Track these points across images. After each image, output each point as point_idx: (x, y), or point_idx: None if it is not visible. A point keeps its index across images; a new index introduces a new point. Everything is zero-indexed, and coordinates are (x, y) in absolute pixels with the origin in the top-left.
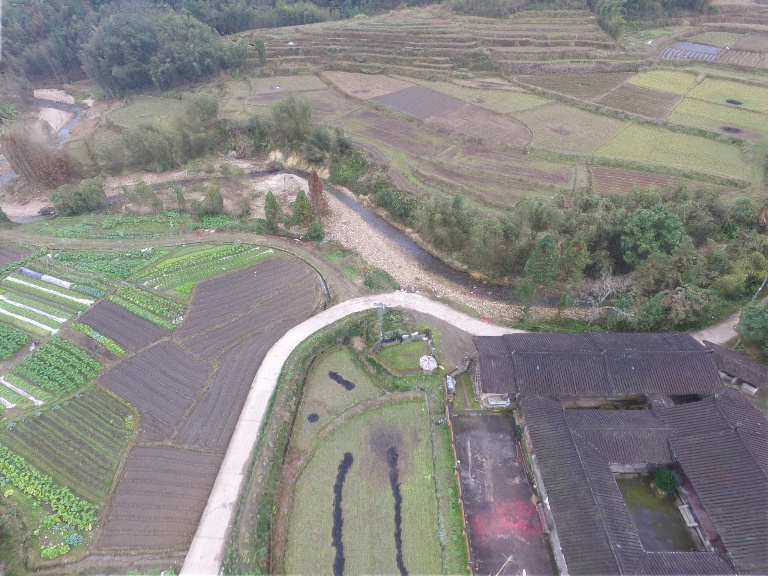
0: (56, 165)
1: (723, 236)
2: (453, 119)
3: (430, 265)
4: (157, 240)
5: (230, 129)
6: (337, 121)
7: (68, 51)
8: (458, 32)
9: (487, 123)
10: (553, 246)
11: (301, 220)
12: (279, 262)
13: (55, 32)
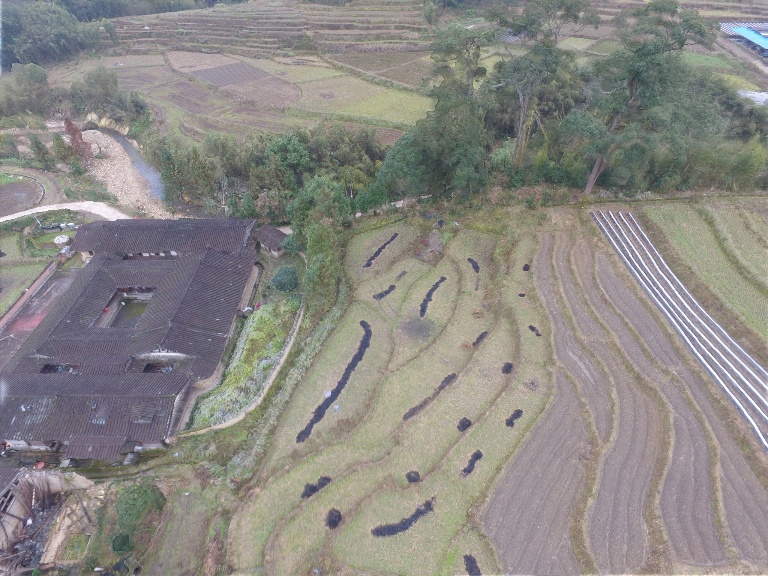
0: None
1: None
2: (245, 87)
3: (158, 193)
4: None
5: (58, 95)
6: (150, 89)
7: None
8: (294, 18)
9: (271, 90)
10: (170, 158)
11: (61, 158)
12: (20, 184)
13: None
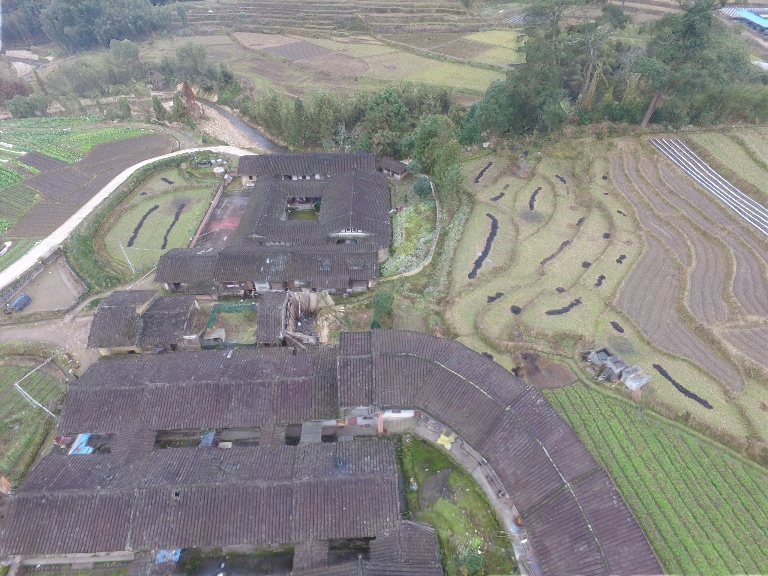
0: (13, 87)
1: (442, 115)
2: (316, 61)
3: (264, 145)
4: (77, 127)
5: (148, 69)
6: (230, 63)
7: (34, 19)
8: (344, 2)
9: (340, 63)
10: None
11: (178, 116)
12: (154, 135)
13: (23, 4)
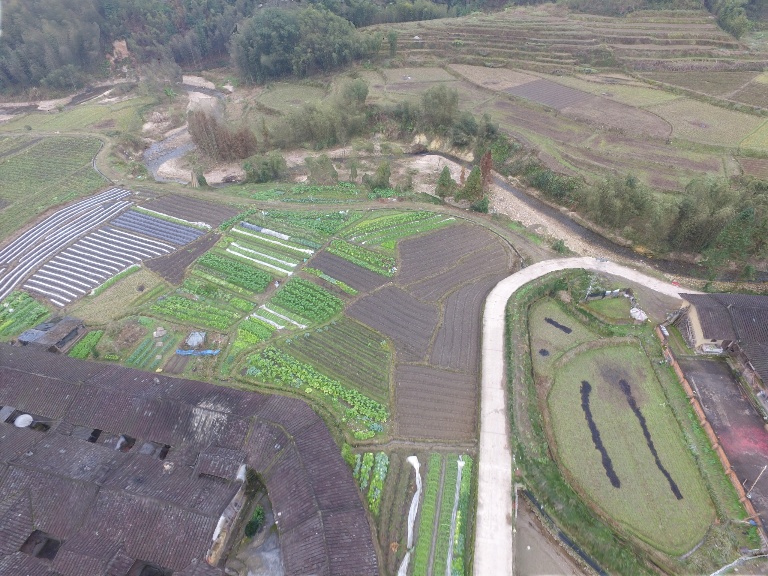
0: (238, 139)
1: None
2: (588, 110)
3: (593, 240)
4: (346, 205)
5: (377, 113)
6: (476, 109)
7: (208, 41)
8: (578, 29)
9: (623, 115)
10: (753, 217)
11: (471, 194)
12: (464, 228)
13: (199, 24)
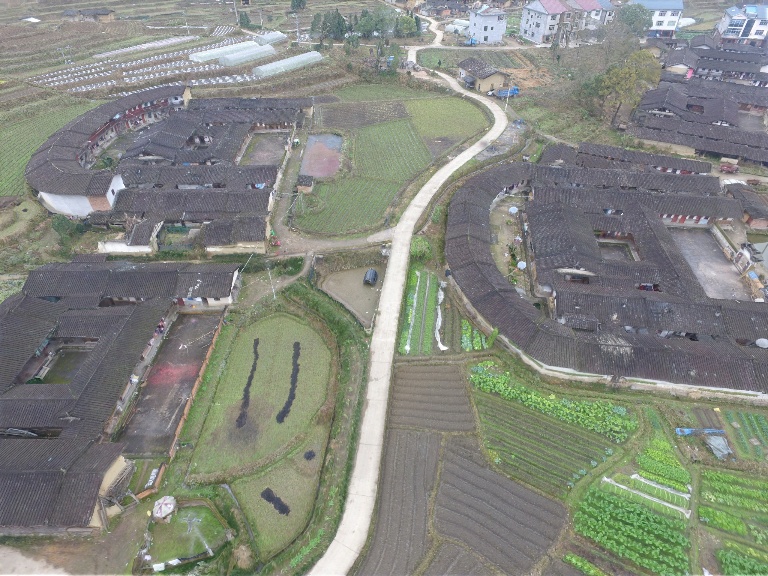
0: None
1: None
2: None
3: None
4: None
5: None
6: None
7: None
8: None
9: None
10: None
11: None
12: None
13: None
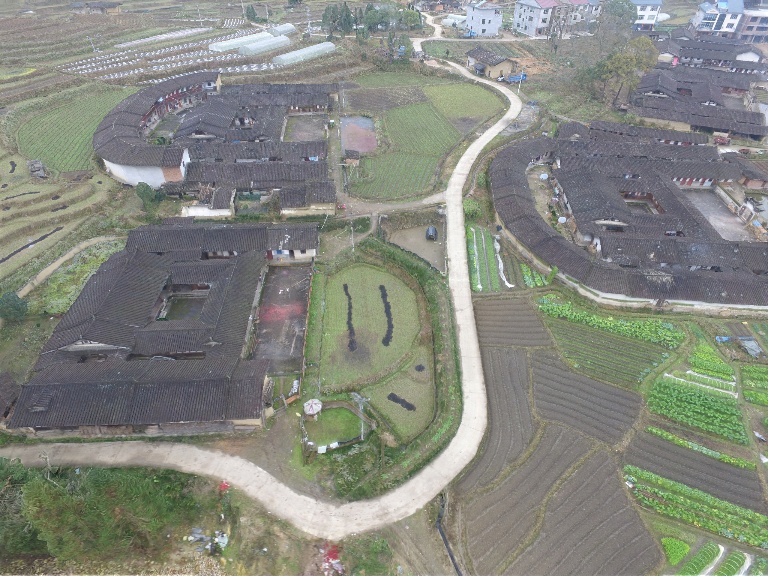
0: None
1: None
2: None
3: None
4: None
5: None
6: None
7: None
8: None
9: None
10: None
11: None
12: None
13: None
